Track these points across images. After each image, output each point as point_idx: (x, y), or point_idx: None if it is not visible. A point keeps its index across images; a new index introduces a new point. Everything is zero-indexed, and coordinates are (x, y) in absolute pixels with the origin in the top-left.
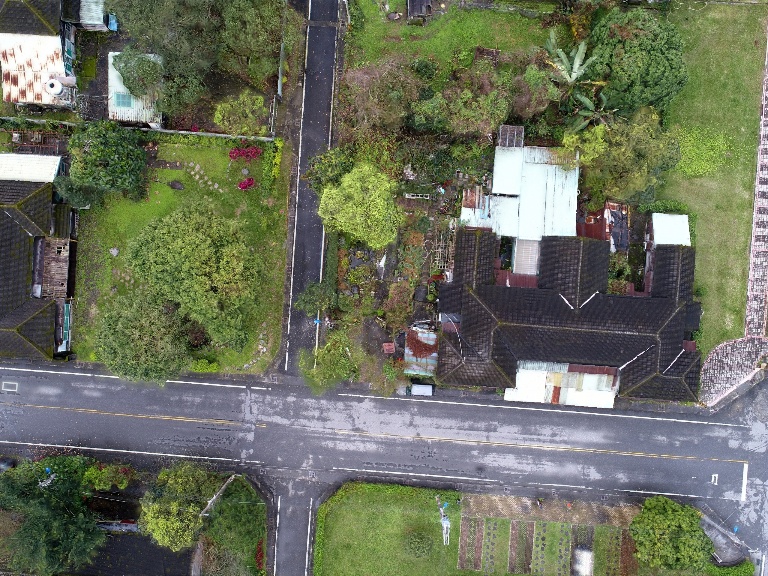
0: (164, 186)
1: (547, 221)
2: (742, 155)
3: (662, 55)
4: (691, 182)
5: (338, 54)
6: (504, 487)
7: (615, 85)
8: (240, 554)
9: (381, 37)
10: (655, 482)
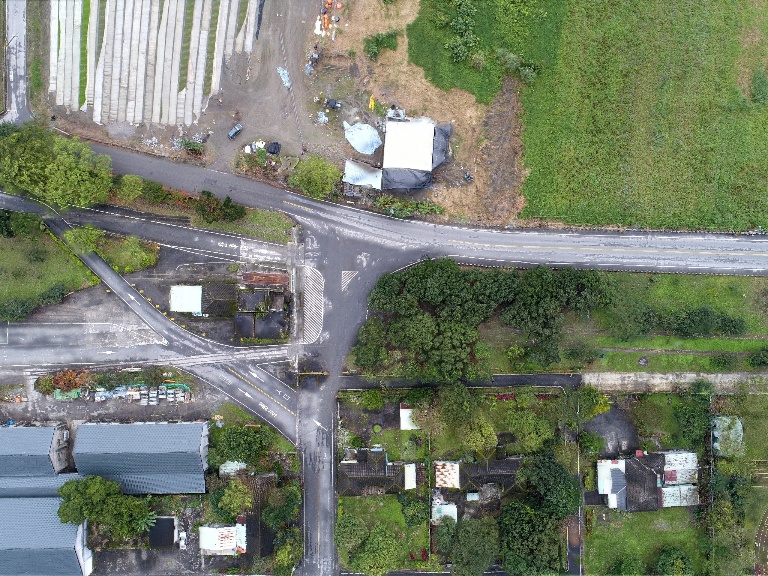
0: None
1: None
2: None
3: None
4: None
5: None
6: None
7: None
8: (271, 569)
9: None
10: None
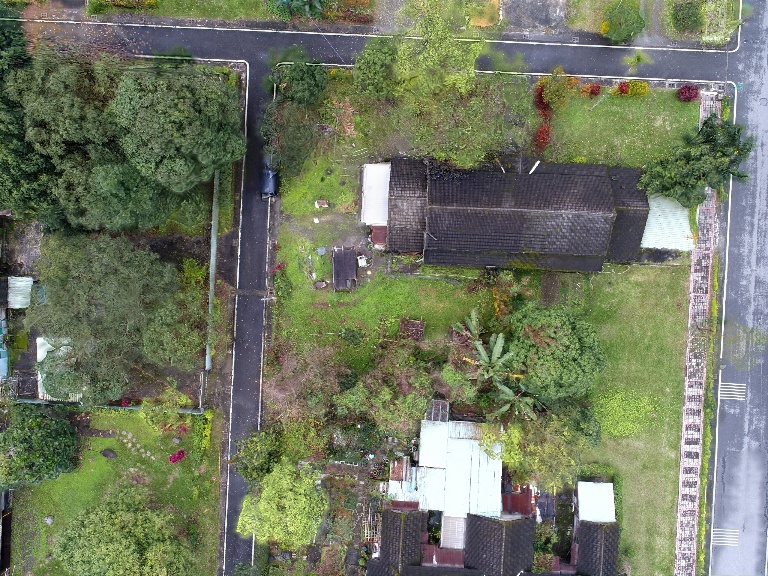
0: (97, 454)
1: (472, 498)
2: (667, 415)
3: (575, 361)
4: (617, 443)
5: (267, 322)
6: None
7: (532, 382)
8: None
9: (309, 304)
10: None
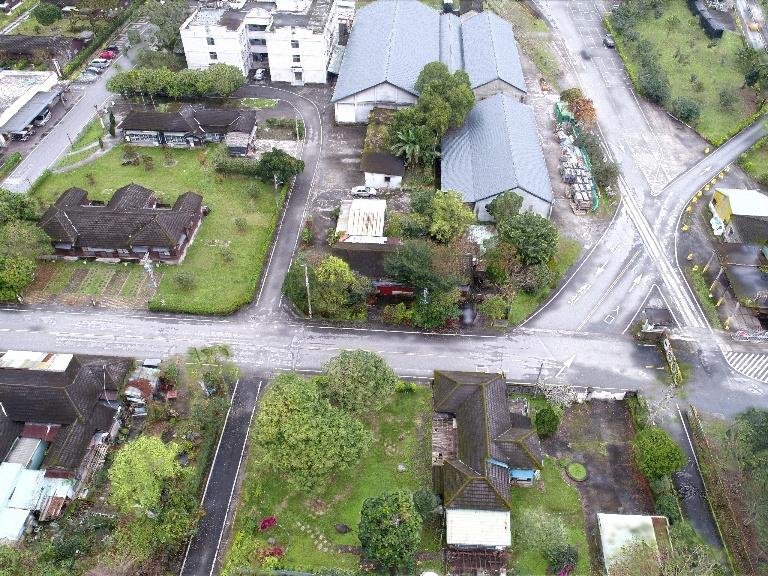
0: (355, 528)
1: None
2: None
3: None
4: None
5: None
6: (115, 312)
7: None
8: None
9: None
10: (4, 315)
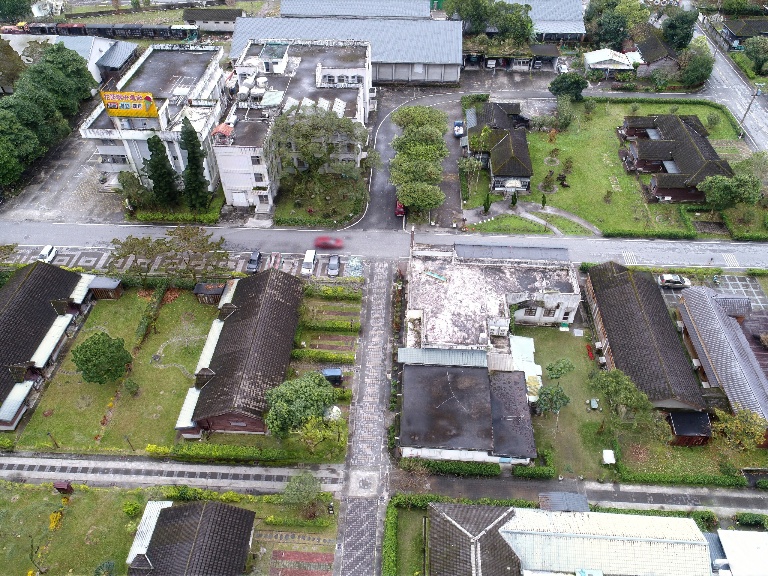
0: None
1: None
2: None
3: None
4: None
5: None
6: None
7: None
8: None
9: None
10: None
